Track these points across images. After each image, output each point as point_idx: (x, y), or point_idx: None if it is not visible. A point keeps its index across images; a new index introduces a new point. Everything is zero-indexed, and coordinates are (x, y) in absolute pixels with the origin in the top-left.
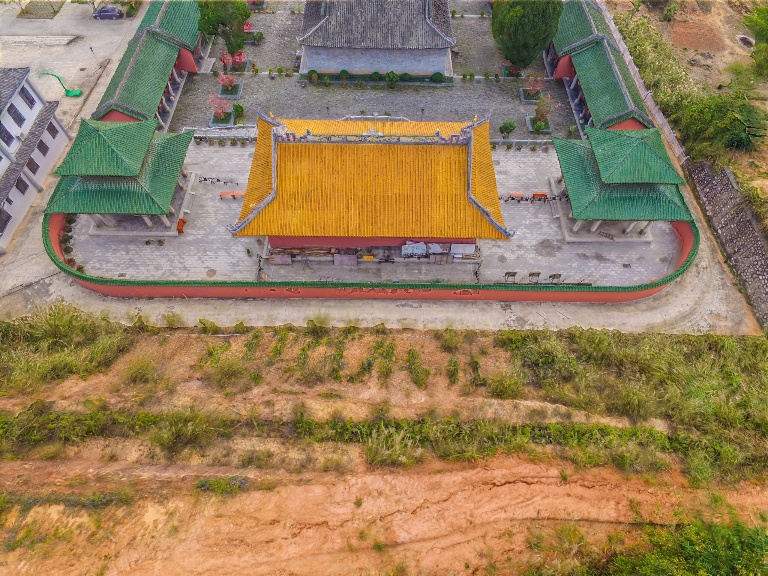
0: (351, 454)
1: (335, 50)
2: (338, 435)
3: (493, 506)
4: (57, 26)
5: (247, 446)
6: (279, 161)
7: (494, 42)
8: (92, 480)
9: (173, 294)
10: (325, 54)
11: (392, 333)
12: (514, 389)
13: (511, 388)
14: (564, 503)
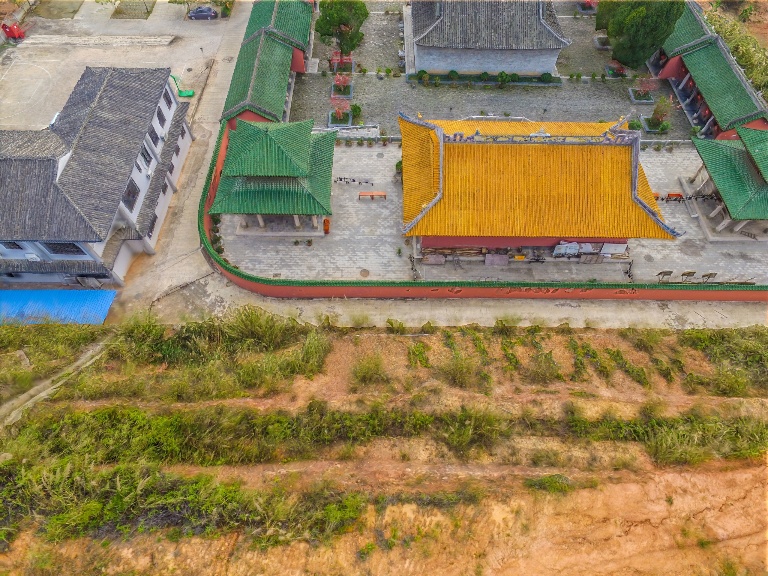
0: (632, 452)
1: (448, 50)
2: (612, 434)
3: None
4: (153, 26)
5: (529, 445)
6: (444, 161)
7: (592, 42)
8: (415, 479)
9: (334, 294)
10: (437, 54)
11: (576, 332)
12: (737, 387)
13: (735, 386)
14: None
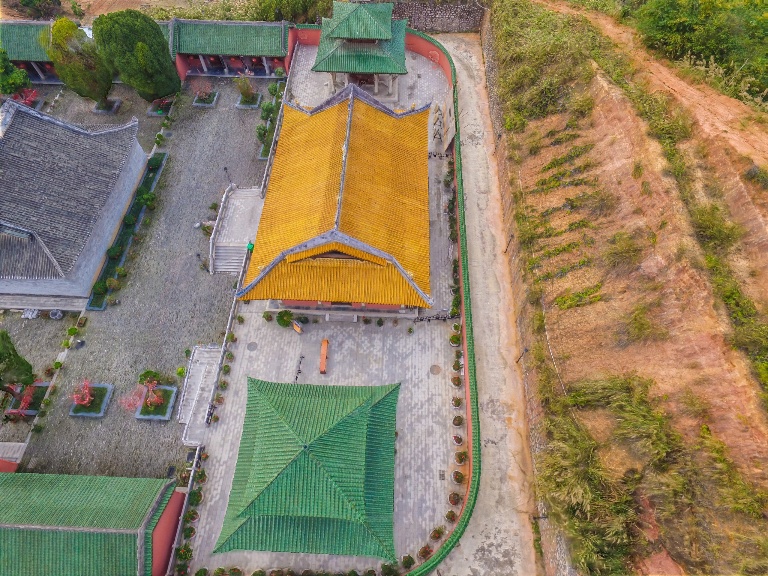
0: (686, 148)
1: None
2: None
3: (690, 90)
4: None
5: (705, 199)
6: None
7: (100, 116)
8: None
9: None
10: (82, 260)
11: None
12: None
13: (582, 104)
14: (666, 74)
